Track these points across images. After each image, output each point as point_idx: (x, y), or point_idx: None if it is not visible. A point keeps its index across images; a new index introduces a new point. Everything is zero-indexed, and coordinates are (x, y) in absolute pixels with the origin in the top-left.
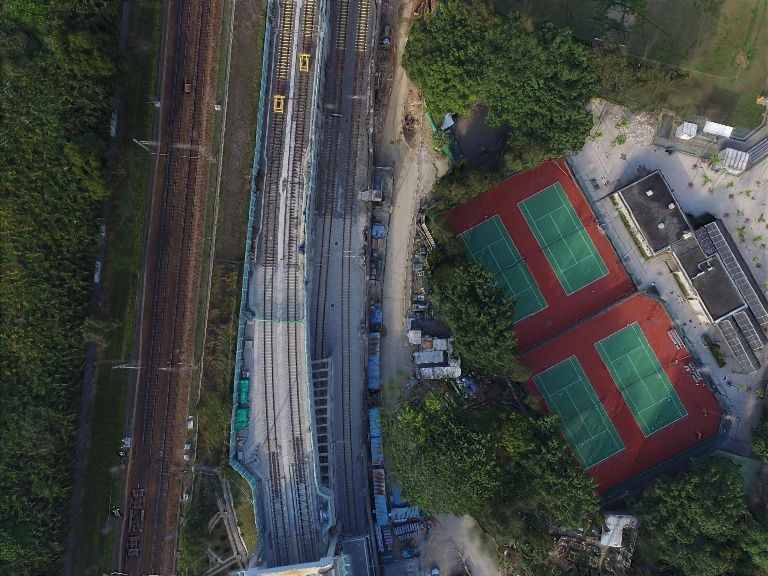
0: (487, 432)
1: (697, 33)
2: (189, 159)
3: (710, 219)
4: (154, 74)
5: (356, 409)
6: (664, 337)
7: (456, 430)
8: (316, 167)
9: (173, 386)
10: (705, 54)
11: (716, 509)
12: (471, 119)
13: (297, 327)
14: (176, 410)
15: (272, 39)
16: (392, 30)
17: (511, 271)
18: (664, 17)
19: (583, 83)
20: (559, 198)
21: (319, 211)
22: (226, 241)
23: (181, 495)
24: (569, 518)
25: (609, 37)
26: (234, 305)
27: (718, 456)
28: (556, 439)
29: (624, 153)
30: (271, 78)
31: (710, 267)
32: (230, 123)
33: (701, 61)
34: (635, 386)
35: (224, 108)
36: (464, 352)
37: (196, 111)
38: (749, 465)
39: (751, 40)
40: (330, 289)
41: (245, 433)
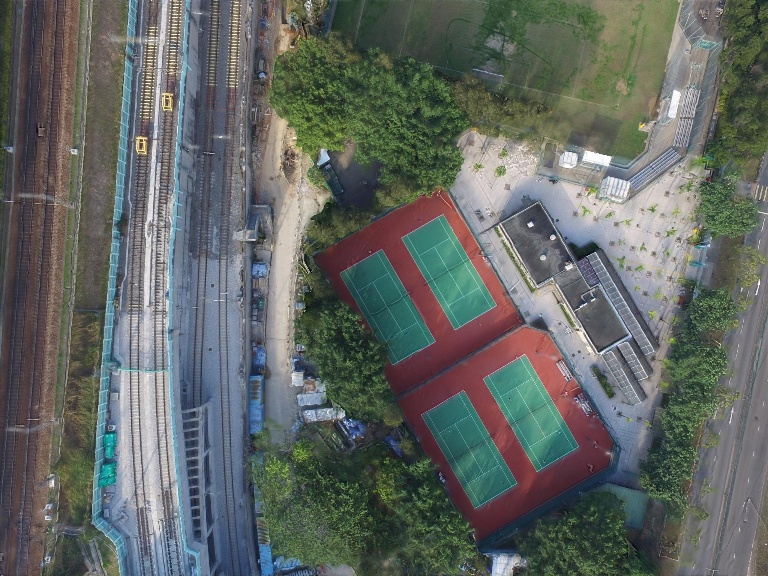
0: (356, 481)
1: (577, 61)
2: (45, 206)
3: (593, 249)
4: (6, 119)
5: (238, 455)
6: (553, 369)
7: (323, 480)
8: (184, 209)
9: (32, 444)
10: (586, 82)
11: (594, 549)
12: (347, 154)
13: (165, 376)
14: (36, 469)
15: (134, 78)
16: (267, 64)
17: (396, 307)
18: (544, 45)
19: (448, 119)
20: (444, 231)
21: (193, 253)
22: (88, 290)
23: (43, 558)
24: (446, 564)
25: (489, 66)
26: (97, 356)
27: (605, 490)
28: (427, 485)
29: (508, 183)
30: (134, 119)
31: (593, 298)
32: (88, 167)
33: (582, 89)
34: (525, 420)
35: (81, 152)
36: (333, 398)
37: (51, 156)
38: (638, 497)
39: (631, 67)
40: (207, 333)
41: (112, 489)
